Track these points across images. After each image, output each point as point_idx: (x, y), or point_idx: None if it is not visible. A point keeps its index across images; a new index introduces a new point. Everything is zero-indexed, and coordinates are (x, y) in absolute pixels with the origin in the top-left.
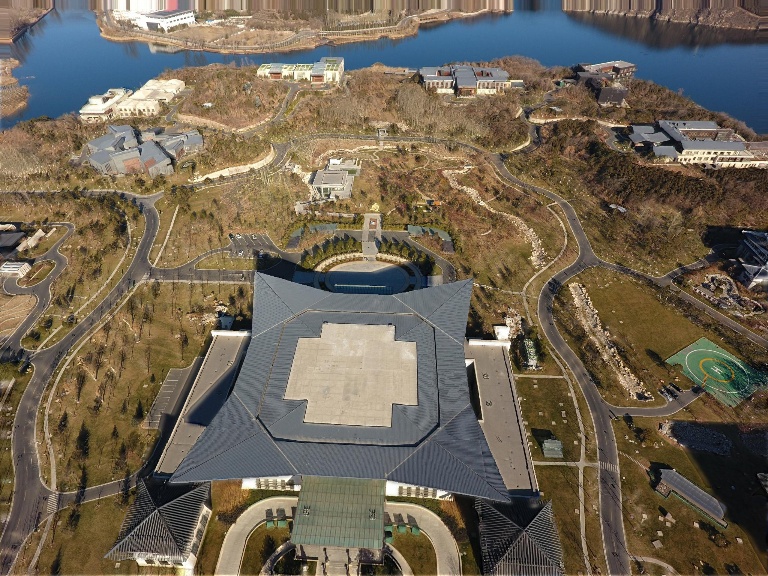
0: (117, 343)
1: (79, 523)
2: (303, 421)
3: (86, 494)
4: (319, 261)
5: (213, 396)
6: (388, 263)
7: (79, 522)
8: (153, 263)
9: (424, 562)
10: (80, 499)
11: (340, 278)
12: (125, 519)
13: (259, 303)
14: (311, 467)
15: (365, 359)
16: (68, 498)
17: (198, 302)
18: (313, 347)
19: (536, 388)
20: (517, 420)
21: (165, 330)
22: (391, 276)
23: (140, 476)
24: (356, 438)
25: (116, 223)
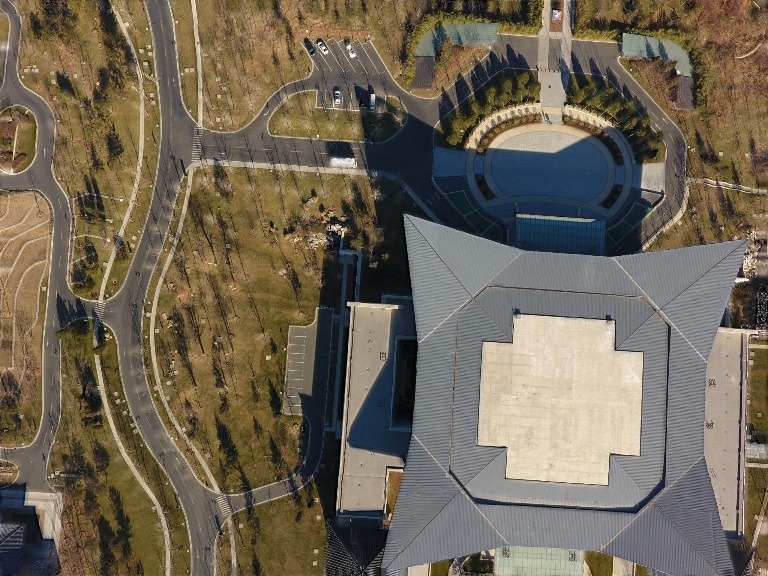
0: (206, 292)
1: (261, 525)
2: (505, 477)
3: (255, 496)
4: (472, 125)
5: (375, 410)
6: (582, 131)
7: (260, 524)
8: (197, 118)
9: (601, 562)
10: (251, 501)
11: (507, 167)
12: (326, 565)
13: (419, 279)
14: (521, 537)
15: (576, 384)
16: (238, 501)
17: (295, 210)
18: (505, 361)
19: (751, 365)
20: (739, 449)
21: (263, 264)
22: (587, 164)
23: (304, 475)
24: (567, 500)
25: (94, 13)
